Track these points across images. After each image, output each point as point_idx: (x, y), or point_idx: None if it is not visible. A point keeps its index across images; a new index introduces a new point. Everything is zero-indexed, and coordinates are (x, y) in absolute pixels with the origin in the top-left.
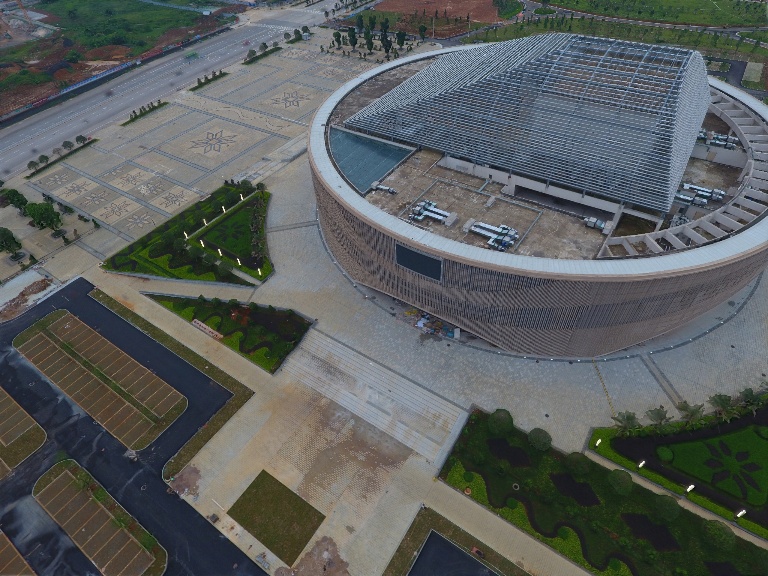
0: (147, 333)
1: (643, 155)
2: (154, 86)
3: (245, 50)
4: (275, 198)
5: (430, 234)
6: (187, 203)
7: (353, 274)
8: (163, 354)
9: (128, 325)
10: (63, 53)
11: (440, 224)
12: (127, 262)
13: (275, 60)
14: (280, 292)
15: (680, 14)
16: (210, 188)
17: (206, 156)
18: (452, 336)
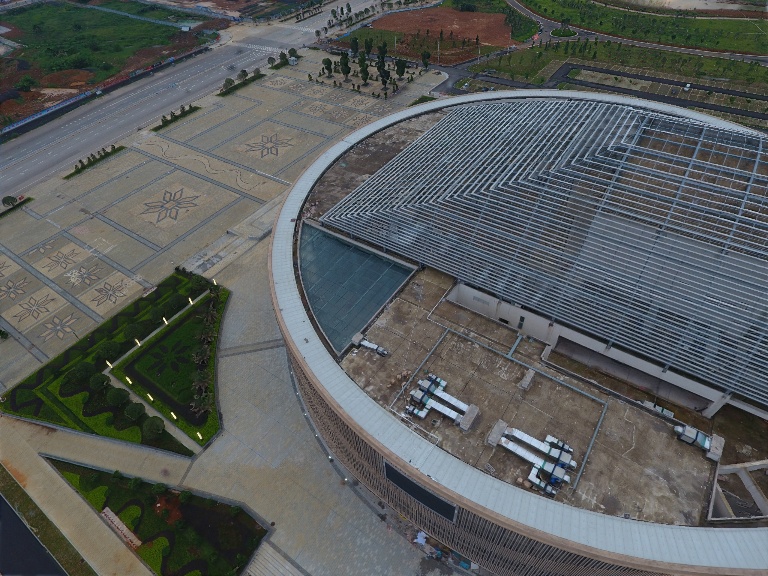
0: (36, 533)
1: (767, 330)
2: (112, 124)
3: (223, 77)
4: (235, 299)
5: (438, 451)
6: (125, 300)
7: (328, 443)
8: (52, 575)
9: (12, 516)
10: (16, 78)
11: (452, 425)
12: (30, 401)
13: (255, 91)
14: (226, 467)
15: (719, 39)
16: (157, 276)
17: (159, 226)
18: (468, 568)
